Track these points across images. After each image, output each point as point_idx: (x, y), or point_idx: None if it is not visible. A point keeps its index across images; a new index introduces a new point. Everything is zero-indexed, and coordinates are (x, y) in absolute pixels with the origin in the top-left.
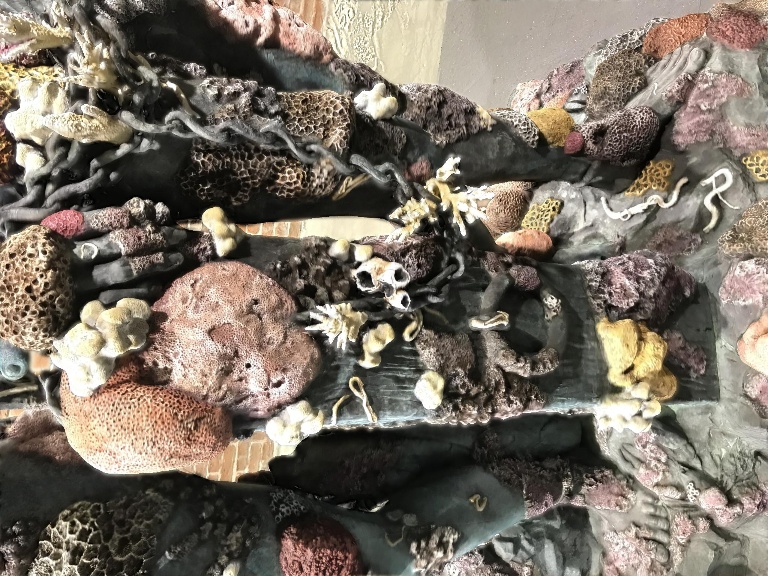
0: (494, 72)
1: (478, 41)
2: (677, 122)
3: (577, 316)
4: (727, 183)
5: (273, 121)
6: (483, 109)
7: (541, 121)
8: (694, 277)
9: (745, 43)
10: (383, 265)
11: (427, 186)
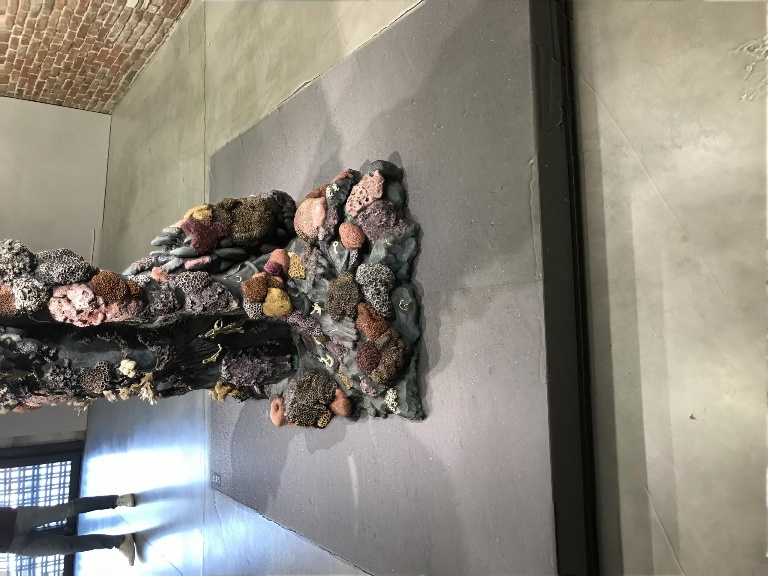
0: (418, 95)
1: (437, 54)
2: (331, 342)
3: (209, 380)
4: None
5: (70, 392)
6: (235, 303)
7: (267, 312)
8: (299, 363)
9: (359, 367)
10: (110, 394)
11: (142, 380)
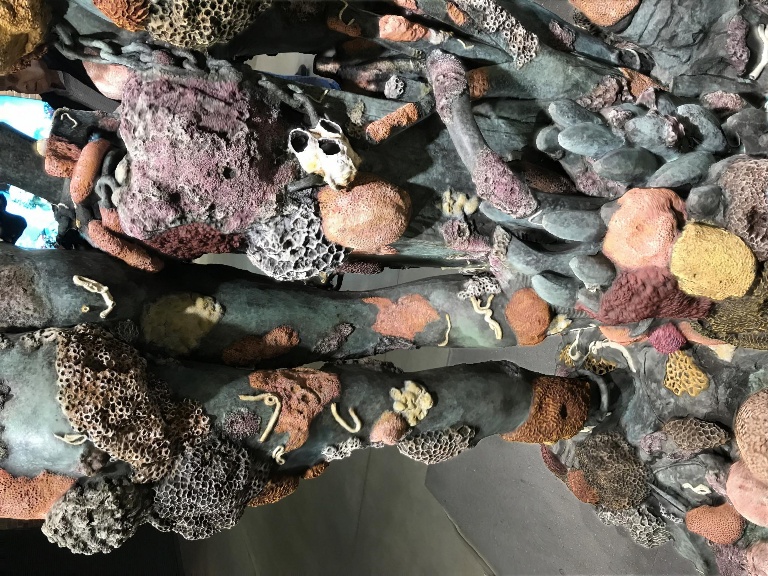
0: None
1: None
2: None
3: None
4: (571, 347)
5: None
6: None
7: None
8: None
9: None
10: None
11: None
